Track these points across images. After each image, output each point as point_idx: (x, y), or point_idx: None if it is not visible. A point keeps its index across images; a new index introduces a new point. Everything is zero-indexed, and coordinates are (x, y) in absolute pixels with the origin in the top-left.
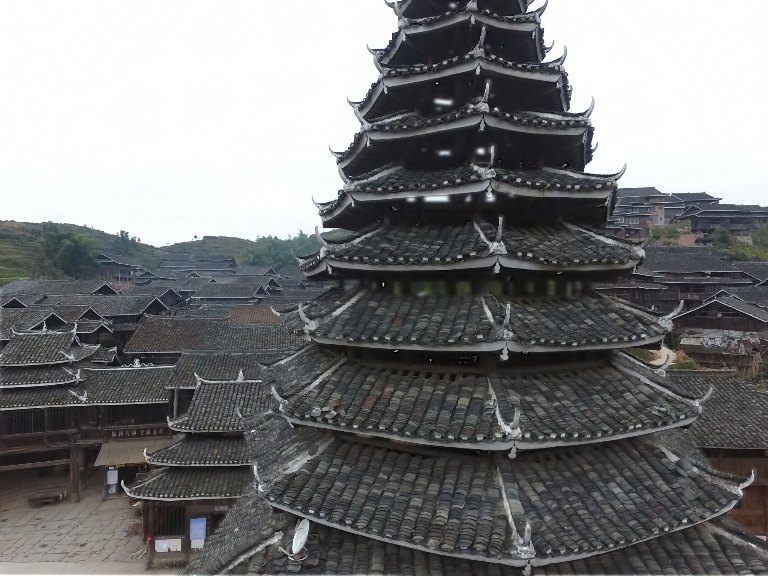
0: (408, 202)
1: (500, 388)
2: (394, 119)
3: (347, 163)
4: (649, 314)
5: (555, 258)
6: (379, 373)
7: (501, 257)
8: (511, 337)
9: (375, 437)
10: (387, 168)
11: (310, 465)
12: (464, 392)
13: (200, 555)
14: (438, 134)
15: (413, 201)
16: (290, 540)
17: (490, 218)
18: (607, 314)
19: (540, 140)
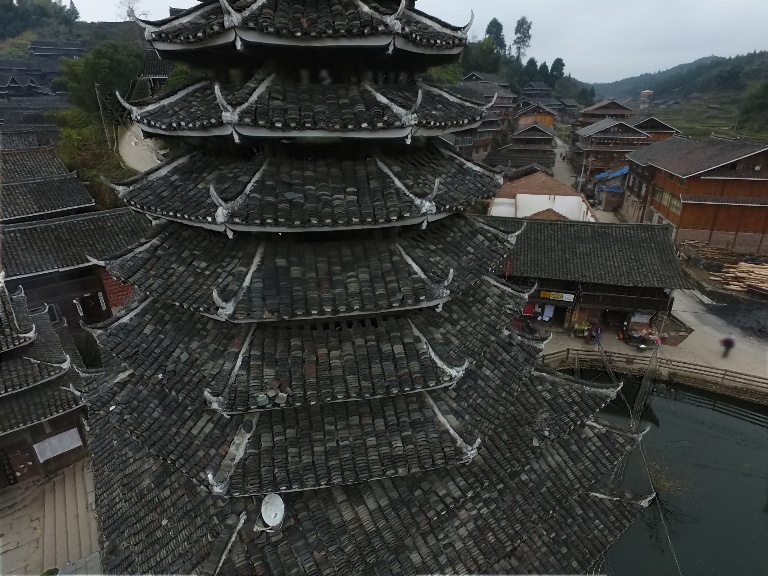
0: (311, 140)
1: (426, 330)
2: (260, 2)
3: (174, 47)
4: (502, 232)
5: (459, 203)
6: (300, 333)
7: (430, 215)
8: (448, 294)
9: (329, 403)
10: (262, 80)
11: (253, 443)
12: (395, 339)
13: (144, 568)
14: (337, 48)
15: (319, 140)
16: (258, 515)
17: (387, 151)
18: (476, 236)
19: (427, 58)
